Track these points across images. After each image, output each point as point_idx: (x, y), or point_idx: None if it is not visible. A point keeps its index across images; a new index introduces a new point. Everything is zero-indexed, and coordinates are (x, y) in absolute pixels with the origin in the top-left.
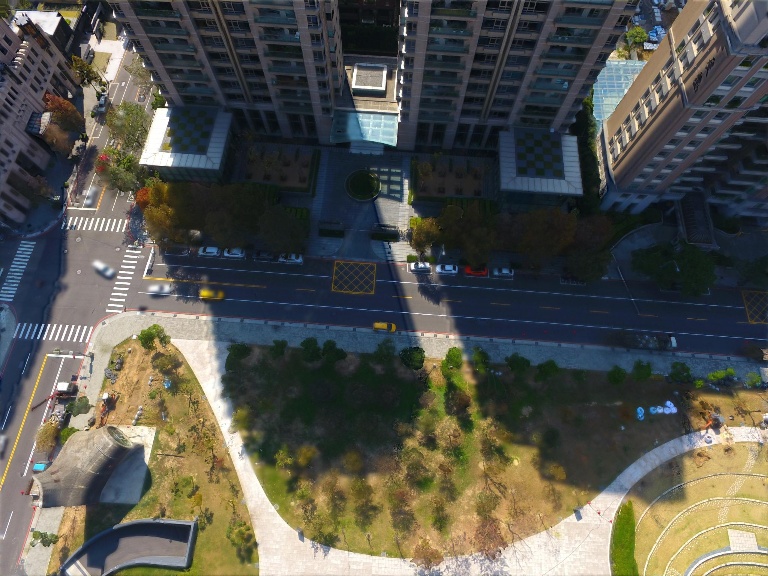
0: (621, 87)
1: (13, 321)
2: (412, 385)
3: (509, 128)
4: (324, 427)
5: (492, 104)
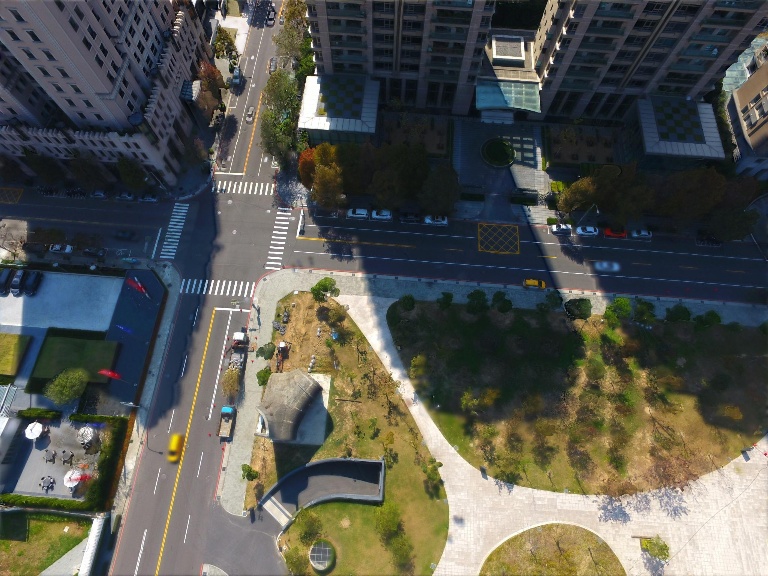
0: (739, 61)
1: (178, 277)
2: (568, 338)
3: (646, 96)
4: (491, 375)
5: (634, 72)
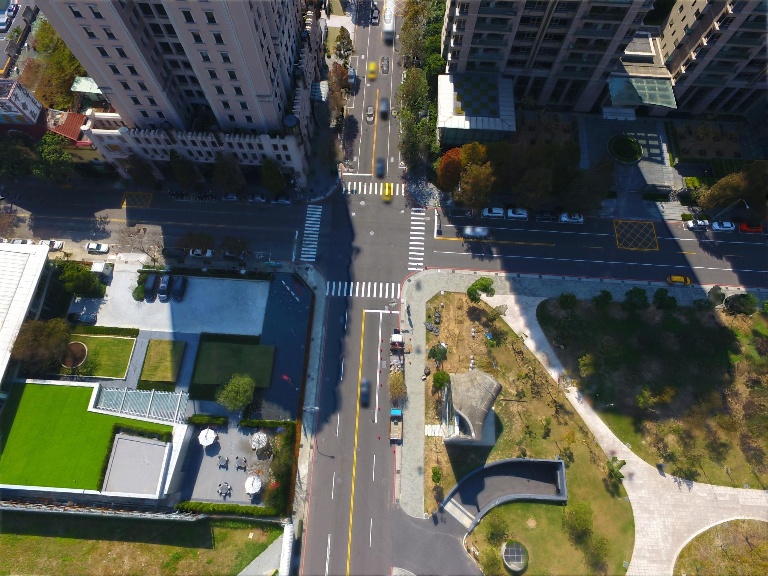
0: None
1: (322, 280)
2: (720, 333)
3: None
4: (651, 372)
5: None
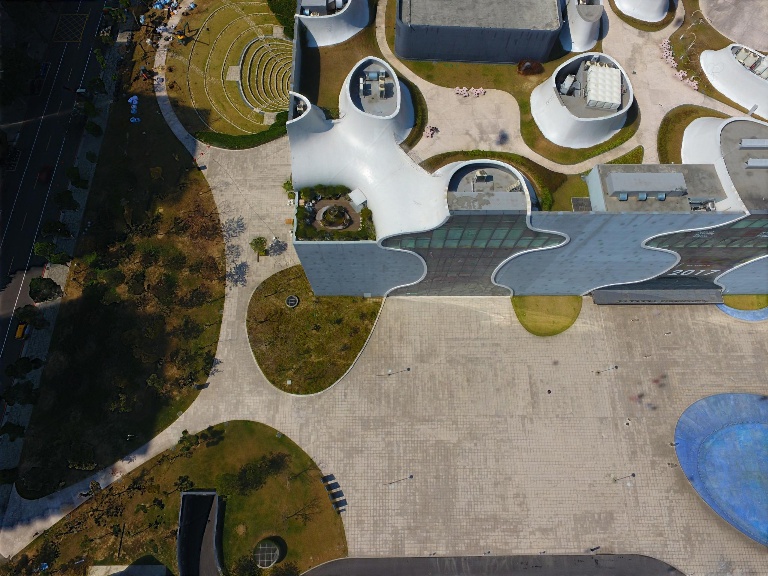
0: None
1: None
2: (87, 298)
3: None
4: None
5: None
